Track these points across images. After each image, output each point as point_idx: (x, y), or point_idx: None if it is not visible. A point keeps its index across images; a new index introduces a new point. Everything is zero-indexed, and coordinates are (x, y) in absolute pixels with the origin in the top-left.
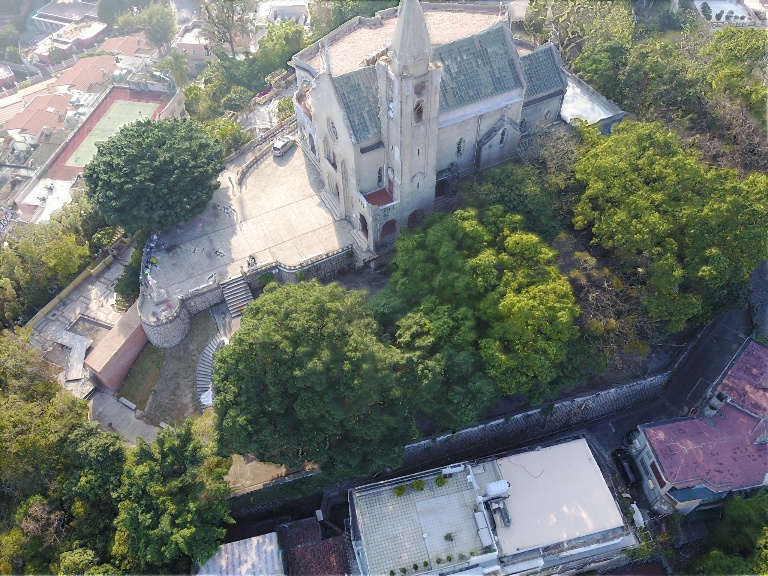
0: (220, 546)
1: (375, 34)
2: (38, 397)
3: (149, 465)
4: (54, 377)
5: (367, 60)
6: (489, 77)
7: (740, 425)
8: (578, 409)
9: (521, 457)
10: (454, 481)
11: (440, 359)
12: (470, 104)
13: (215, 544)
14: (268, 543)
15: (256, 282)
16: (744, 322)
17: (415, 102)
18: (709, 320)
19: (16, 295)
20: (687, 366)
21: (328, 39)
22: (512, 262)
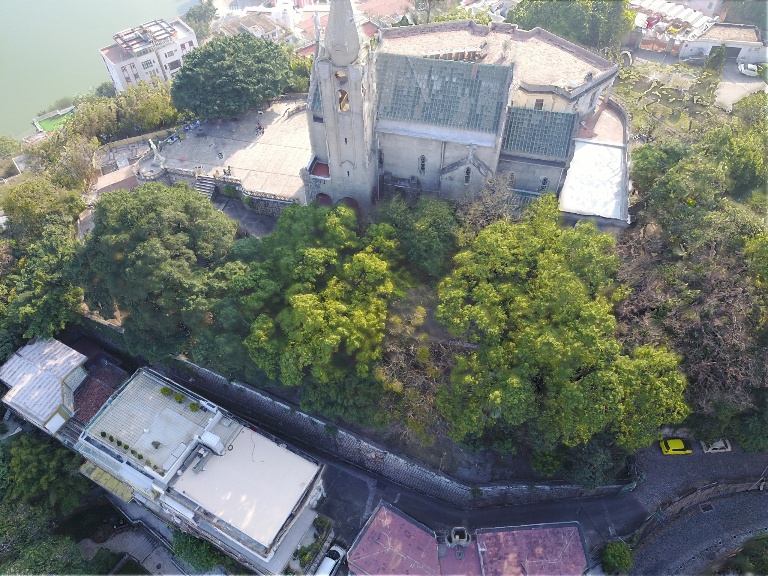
0: (56, 340)
1: (469, 40)
2: (57, 183)
3: (48, 256)
4: (90, 182)
5: (424, 56)
6: (468, 109)
7: (463, 575)
8: (369, 454)
9: (261, 439)
10: (204, 415)
11: (212, 302)
12: (434, 125)
13: (47, 334)
14: (76, 360)
15: (224, 189)
16: (631, 521)
17: (337, 90)
18: (549, 474)
19: (116, 119)
20: (522, 509)
21: (425, 27)
22: (356, 277)
